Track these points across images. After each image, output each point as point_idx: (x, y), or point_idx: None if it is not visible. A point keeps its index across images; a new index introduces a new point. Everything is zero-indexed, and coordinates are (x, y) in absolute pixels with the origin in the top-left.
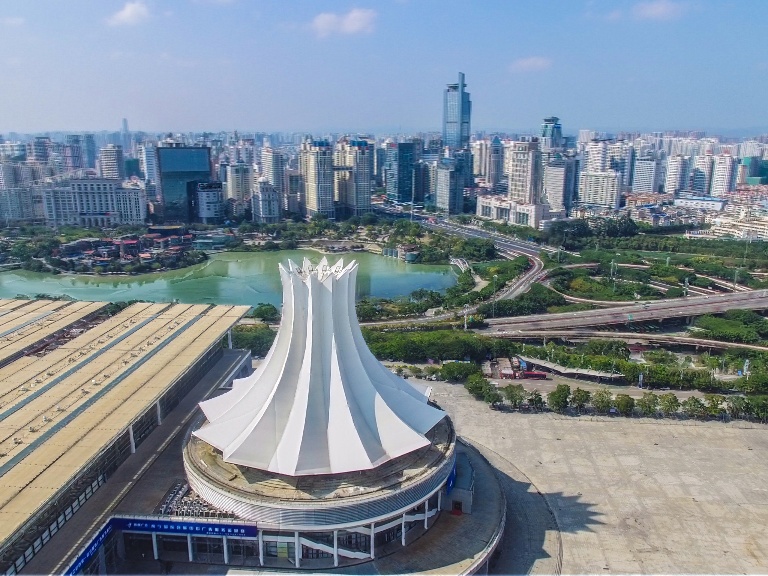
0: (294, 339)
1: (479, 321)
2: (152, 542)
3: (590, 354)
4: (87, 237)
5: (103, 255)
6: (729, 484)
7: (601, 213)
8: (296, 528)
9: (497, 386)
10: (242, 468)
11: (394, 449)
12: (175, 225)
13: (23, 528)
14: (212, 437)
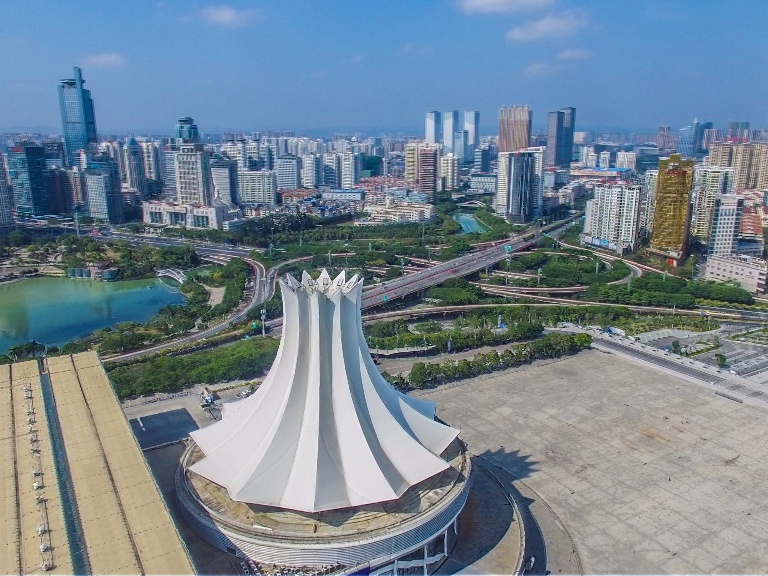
0: (322, 362)
1: None
2: None
3: (380, 336)
4: None
5: None
6: (575, 406)
7: (277, 210)
8: (406, 551)
9: None
10: (313, 516)
11: (435, 446)
12: None
13: None
14: (258, 496)
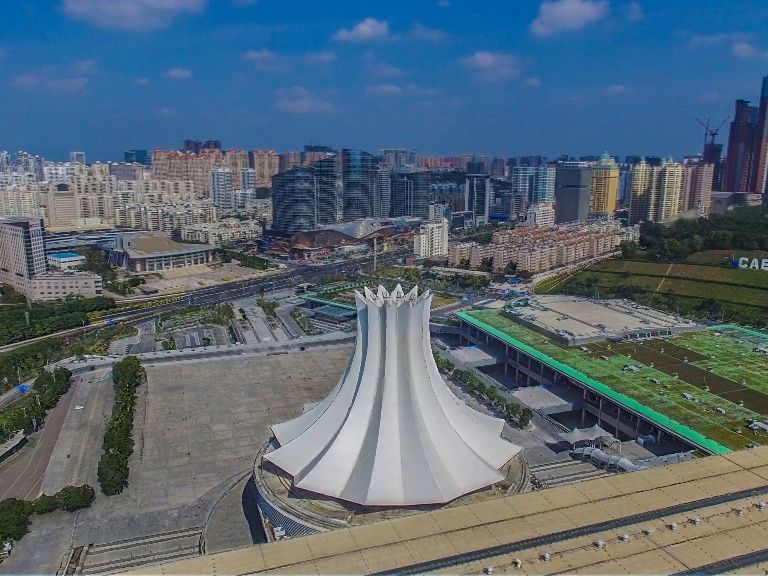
0: None
1: None
2: None
3: None
4: None
5: None
6: (242, 400)
7: None
8: None
9: None
10: None
11: None
12: None
13: None
14: None
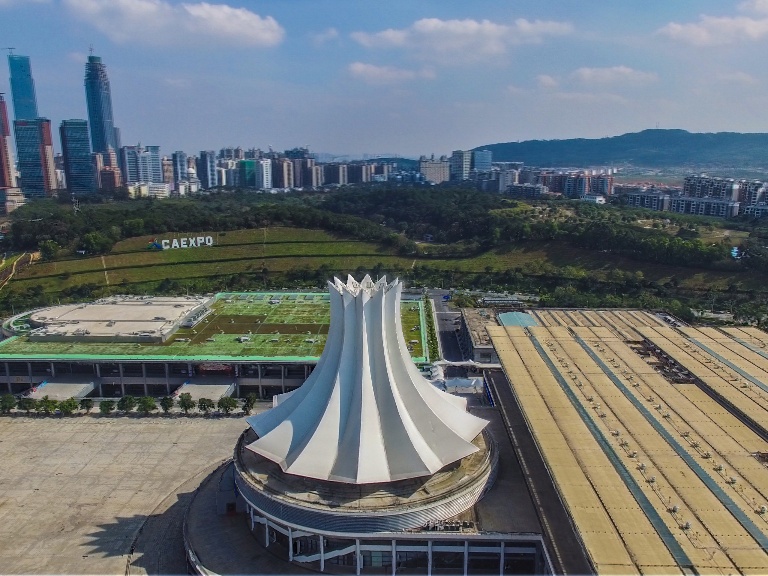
0: None
1: None
2: None
3: None
4: None
5: None
6: None
7: None
8: None
9: None
10: None
11: None
12: None
13: None
14: None
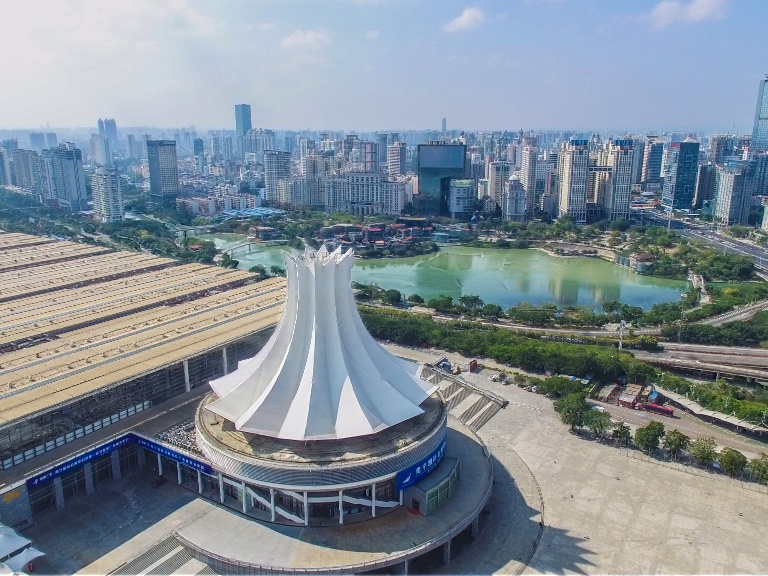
0: (287, 315)
1: (650, 343)
2: (158, 460)
3: None
4: (344, 223)
5: (352, 239)
6: None
7: None
8: (236, 476)
9: (601, 411)
10: None
11: (344, 431)
12: (425, 217)
13: (30, 416)
14: (220, 388)
